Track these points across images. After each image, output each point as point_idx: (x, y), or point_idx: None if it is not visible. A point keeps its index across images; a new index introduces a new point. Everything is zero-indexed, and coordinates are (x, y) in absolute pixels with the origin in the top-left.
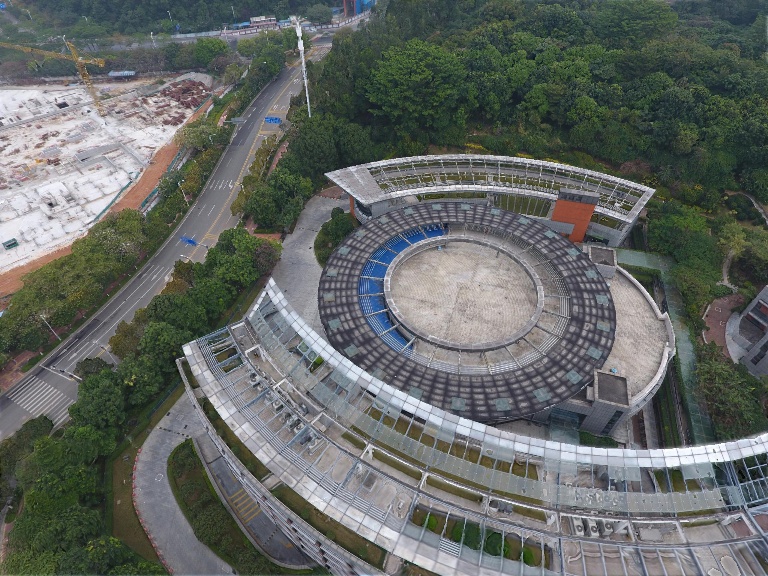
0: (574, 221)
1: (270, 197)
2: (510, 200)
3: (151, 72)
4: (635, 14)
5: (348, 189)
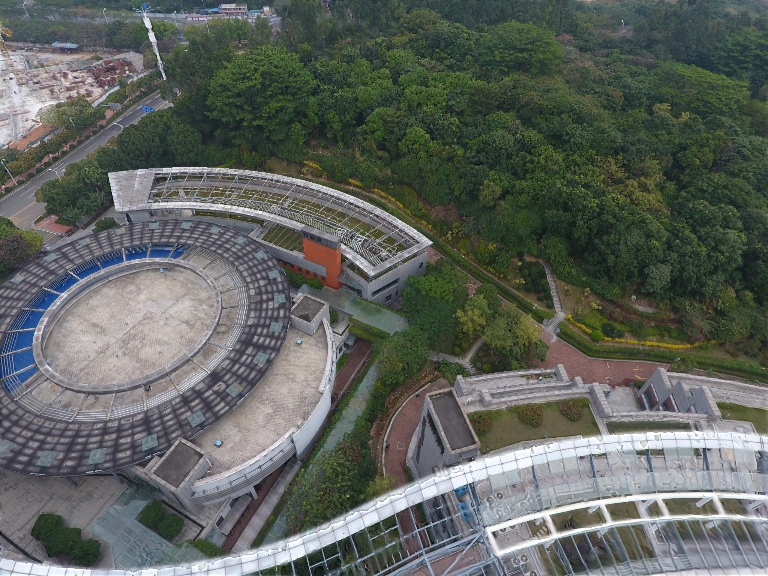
0: (324, 263)
1: (60, 189)
2: (288, 229)
3: (95, 47)
4: (513, 43)
5: (115, 193)
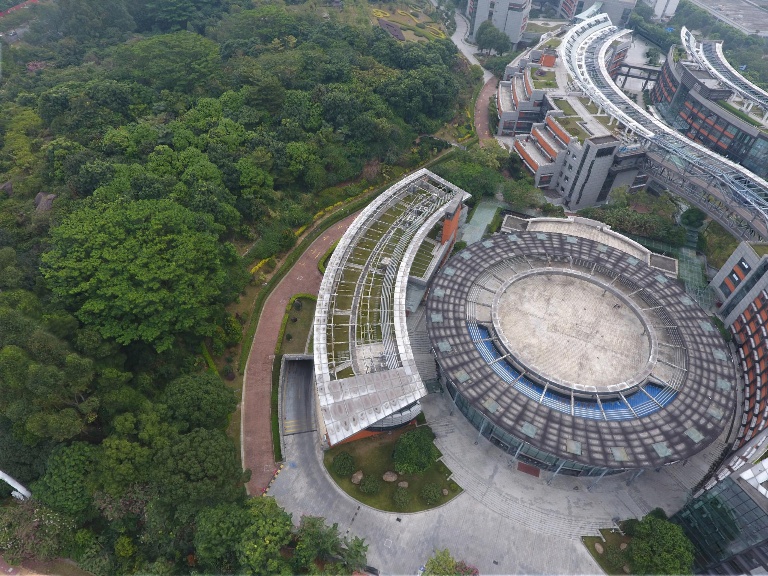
0: None
1: None
2: None
3: None
4: (189, 54)
5: (385, 412)
